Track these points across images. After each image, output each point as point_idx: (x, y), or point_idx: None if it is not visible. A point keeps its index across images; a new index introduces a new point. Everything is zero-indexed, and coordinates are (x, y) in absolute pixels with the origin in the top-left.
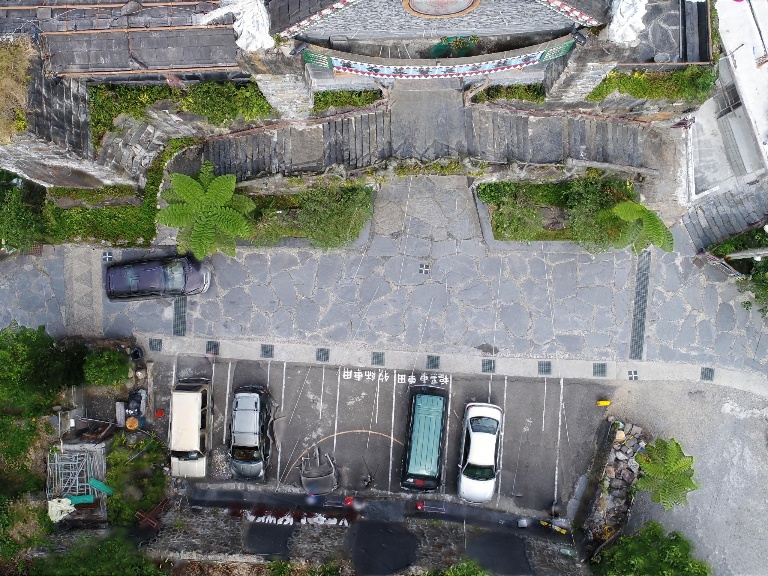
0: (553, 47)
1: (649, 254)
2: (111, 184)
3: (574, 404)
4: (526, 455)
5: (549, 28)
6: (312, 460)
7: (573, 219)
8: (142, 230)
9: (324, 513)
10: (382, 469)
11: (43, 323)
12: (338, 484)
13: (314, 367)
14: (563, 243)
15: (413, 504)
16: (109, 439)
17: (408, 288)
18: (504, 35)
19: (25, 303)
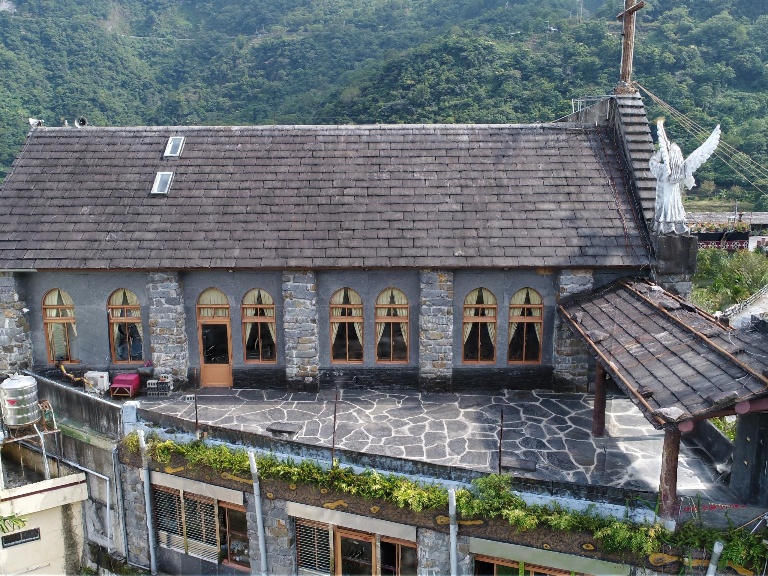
0: None
1: None
2: None
3: None
4: None
5: None
6: None
7: None
8: None
9: None
10: None
11: None
12: None
13: None
14: None
15: None
16: None
17: None
18: None
19: None
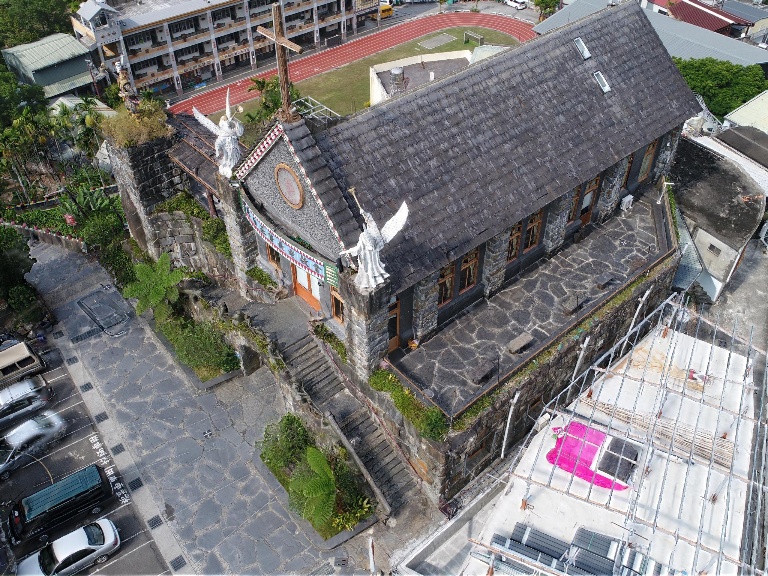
0: (328, 264)
1: (332, 571)
2: None
3: None
4: None
5: None
6: None
7: None
8: None
9: None
10: None
11: (45, 284)
12: None
13: (89, 418)
14: None
15: None
16: None
17: (187, 434)
18: None
19: (54, 272)
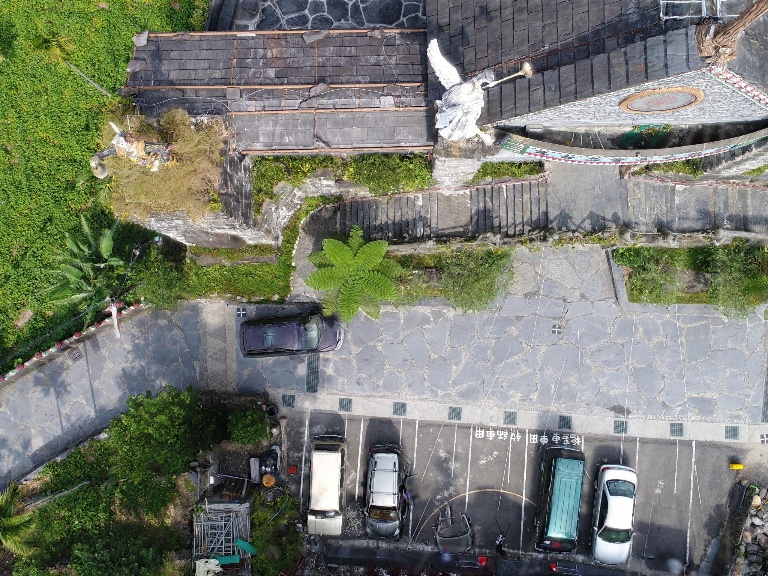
0: (752, 140)
1: None
2: (252, 243)
3: (706, 467)
4: (658, 517)
5: (745, 119)
6: (444, 518)
7: (717, 287)
8: (277, 287)
9: (459, 573)
10: (514, 528)
11: (177, 377)
12: (472, 544)
13: (446, 425)
14: (697, 306)
15: (547, 565)
16: (250, 498)
17: (541, 348)
18: (696, 124)
19: (159, 357)
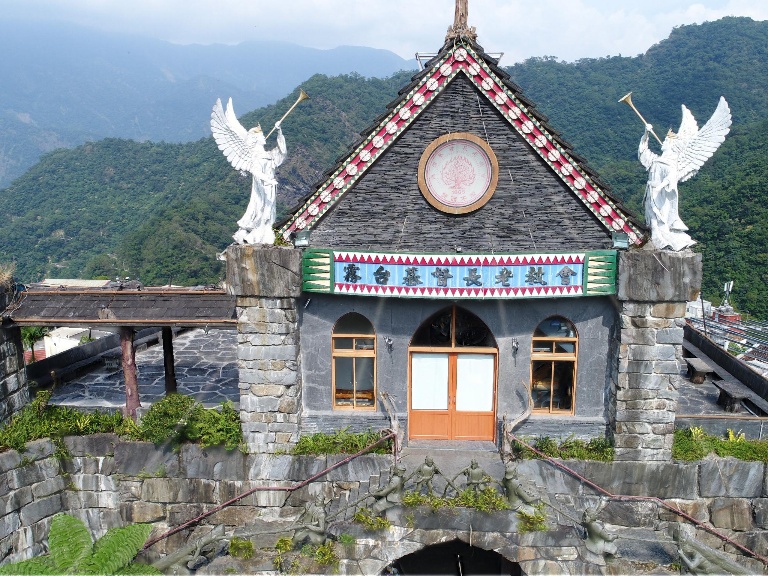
0: (592, 252)
1: None
2: None
3: None
4: None
5: None
6: None
7: None
8: None
9: None
10: None
11: None
12: None
13: None
14: None
15: None
16: None
17: None
18: None
19: None
